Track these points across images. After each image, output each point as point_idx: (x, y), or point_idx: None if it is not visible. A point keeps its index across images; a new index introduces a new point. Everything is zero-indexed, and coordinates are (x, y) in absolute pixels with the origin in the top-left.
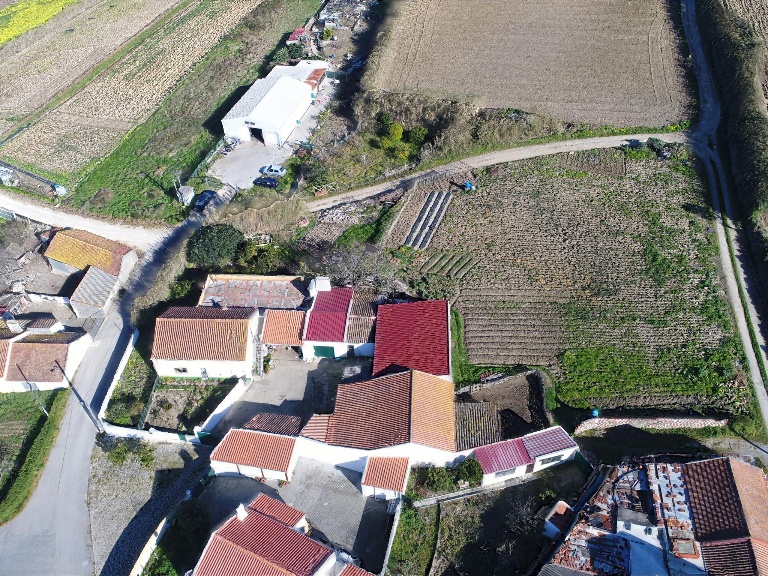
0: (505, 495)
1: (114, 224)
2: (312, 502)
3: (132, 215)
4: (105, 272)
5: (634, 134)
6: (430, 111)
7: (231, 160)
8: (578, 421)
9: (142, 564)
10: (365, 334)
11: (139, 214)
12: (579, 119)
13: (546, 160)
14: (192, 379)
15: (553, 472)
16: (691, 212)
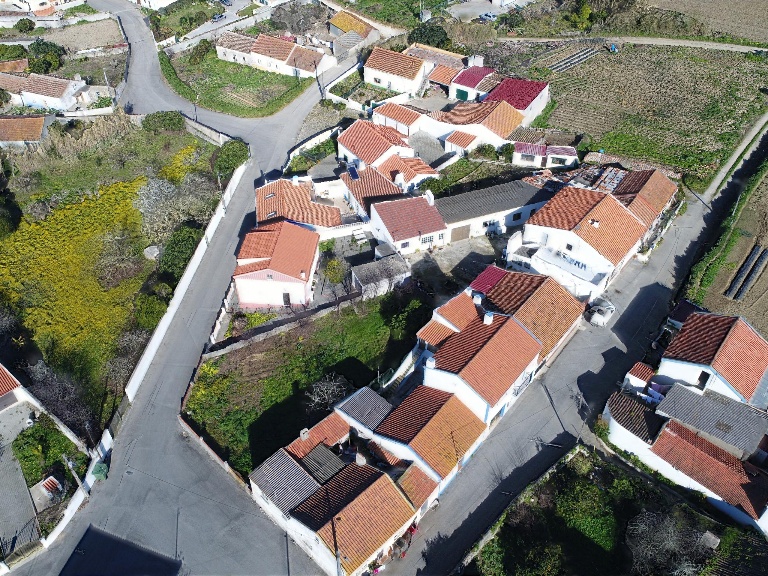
0: (522, 169)
1: (375, 22)
2: (416, 146)
3: (388, 20)
4: (358, 35)
5: (764, 48)
6: (615, 1)
7: (464, 6)
8: (588, 152)
9: (320, 139)
10: (489, 88)
11: (392, 20)
12: (728, 31)
13: (683, 48)
14: (382, 89)
15: (558, 170)
16: (763, 93)
